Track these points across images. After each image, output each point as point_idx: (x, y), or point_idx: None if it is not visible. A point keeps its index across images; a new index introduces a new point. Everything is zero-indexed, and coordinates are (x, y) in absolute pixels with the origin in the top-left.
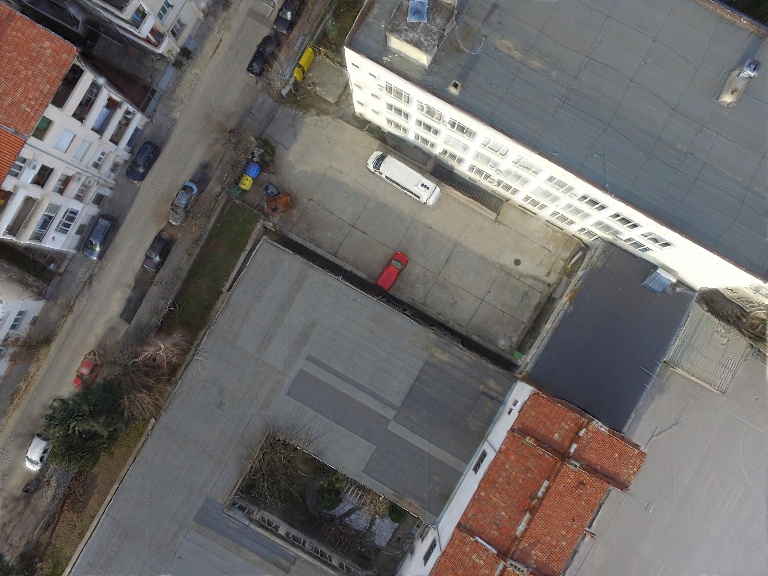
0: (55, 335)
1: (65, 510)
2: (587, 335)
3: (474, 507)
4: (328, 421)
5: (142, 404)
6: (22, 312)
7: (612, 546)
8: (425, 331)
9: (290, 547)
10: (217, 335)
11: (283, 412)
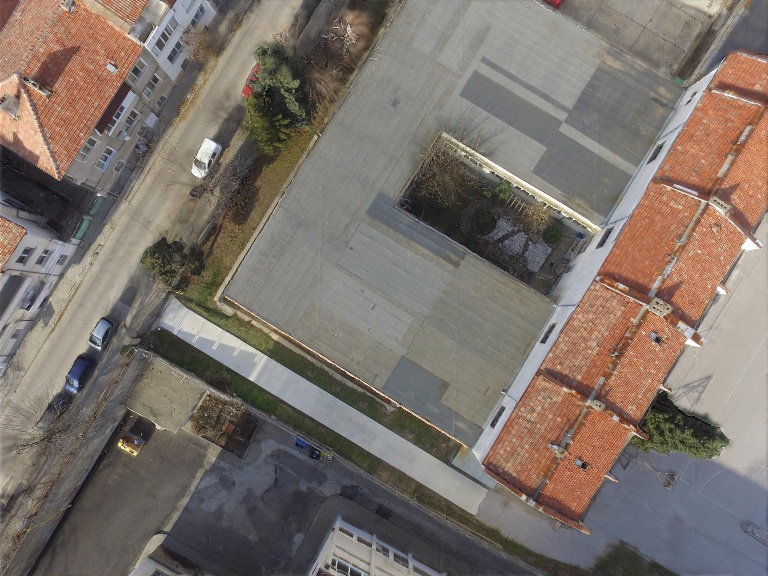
0: (223, 49)
1: (226, 222)
2: (762, 38)
3: (670, 159)
4: (500, 122)
5: (319, 97)
6: (202, 7)
7: (758, 285)
8: (597, 39)
9: (459, 244)
10: (392, 38)
11: (455, 113)
